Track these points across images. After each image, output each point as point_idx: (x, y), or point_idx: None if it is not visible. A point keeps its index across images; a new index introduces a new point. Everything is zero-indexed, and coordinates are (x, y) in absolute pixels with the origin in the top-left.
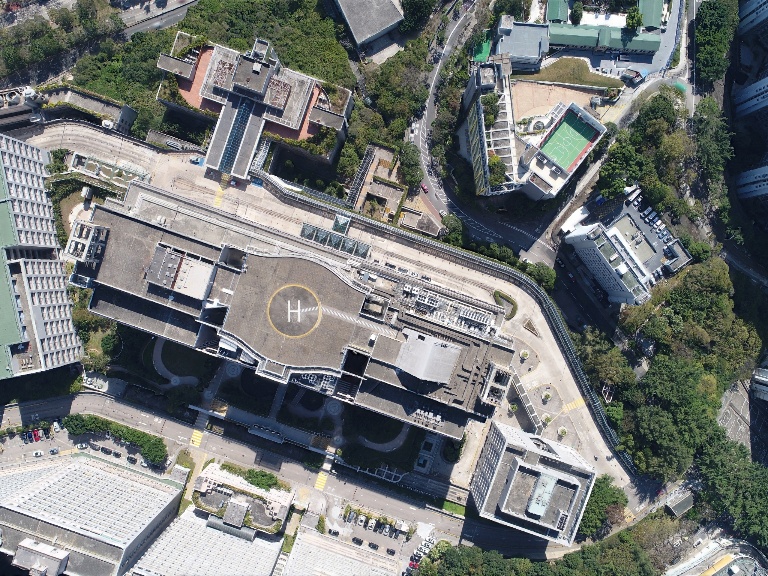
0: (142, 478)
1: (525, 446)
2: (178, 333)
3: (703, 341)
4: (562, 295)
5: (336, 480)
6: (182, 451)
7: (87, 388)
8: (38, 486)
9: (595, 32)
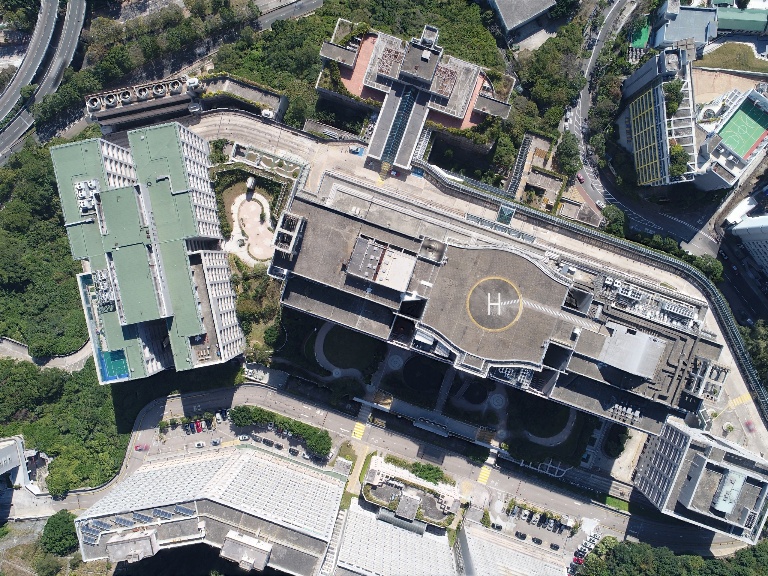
0: (307, 470)
1: (709, 442)
2: (371, 326)
3: None
4: (725, 288)
5: (499, 474)
6: (344, 443)
7: (249, 380)
8: (226, 478)
9: (763, 16)
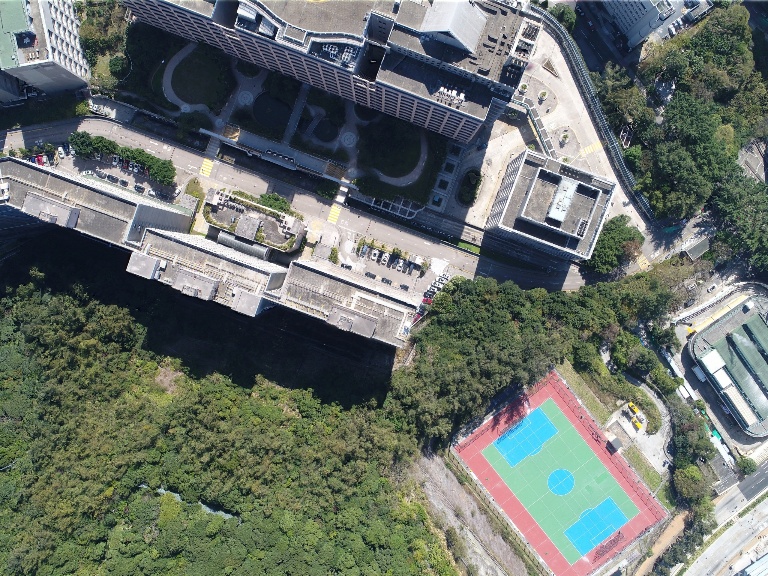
0: None
1: (546, 156)
2: (194, 4)
3: (723, 83)
4: (581, 44)
5: (350, 213)
6: (192, 180)
7: (94, 113)
8: None
9: None
